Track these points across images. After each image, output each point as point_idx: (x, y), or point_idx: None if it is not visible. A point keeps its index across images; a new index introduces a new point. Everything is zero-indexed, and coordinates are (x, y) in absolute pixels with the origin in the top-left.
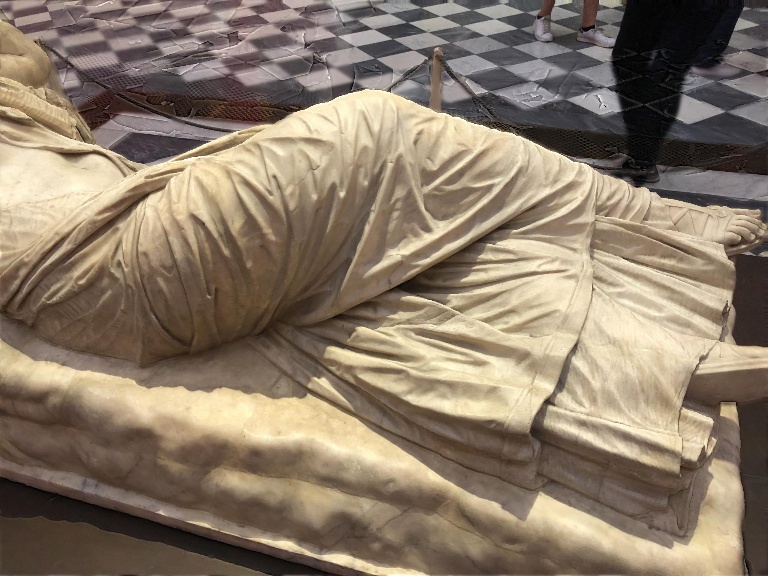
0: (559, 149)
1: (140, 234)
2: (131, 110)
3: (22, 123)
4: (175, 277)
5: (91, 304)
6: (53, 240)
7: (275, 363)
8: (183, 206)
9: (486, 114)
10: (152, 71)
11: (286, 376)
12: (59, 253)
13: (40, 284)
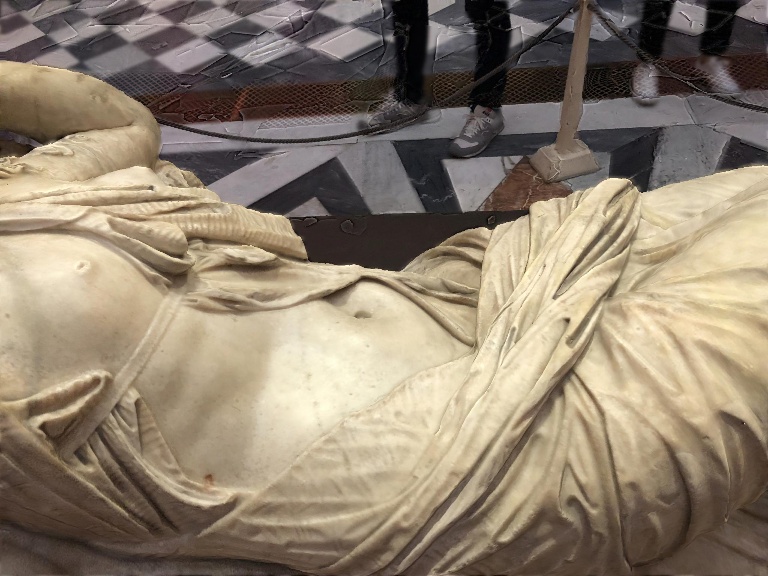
0: (674, 87)
1: (615, 453)
2: (172, 136)
3: (264, 267)
4: (677, 506)
5: (512, 561)
6: (450, 485)
7: (740, 550)
8: (696, 398)
9: (654, 70)
10: (185, 79)
11: (763, 566)
12: (464, 504)
13: (426, 552)
